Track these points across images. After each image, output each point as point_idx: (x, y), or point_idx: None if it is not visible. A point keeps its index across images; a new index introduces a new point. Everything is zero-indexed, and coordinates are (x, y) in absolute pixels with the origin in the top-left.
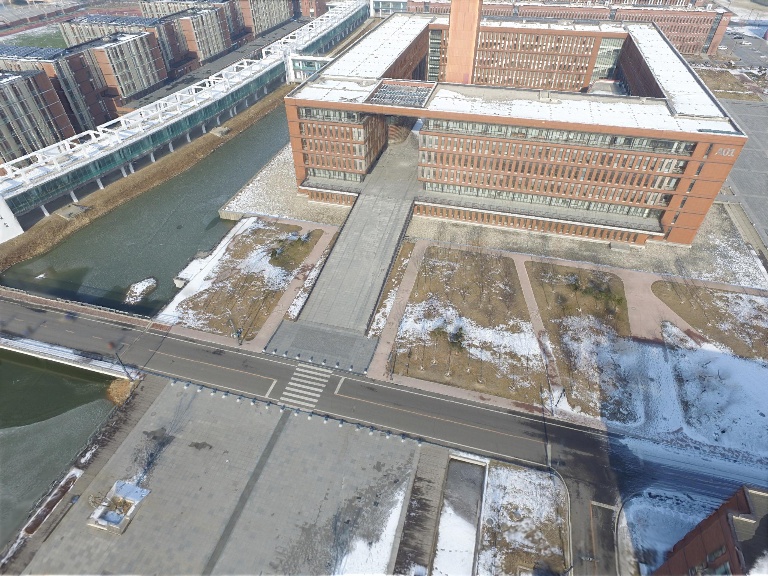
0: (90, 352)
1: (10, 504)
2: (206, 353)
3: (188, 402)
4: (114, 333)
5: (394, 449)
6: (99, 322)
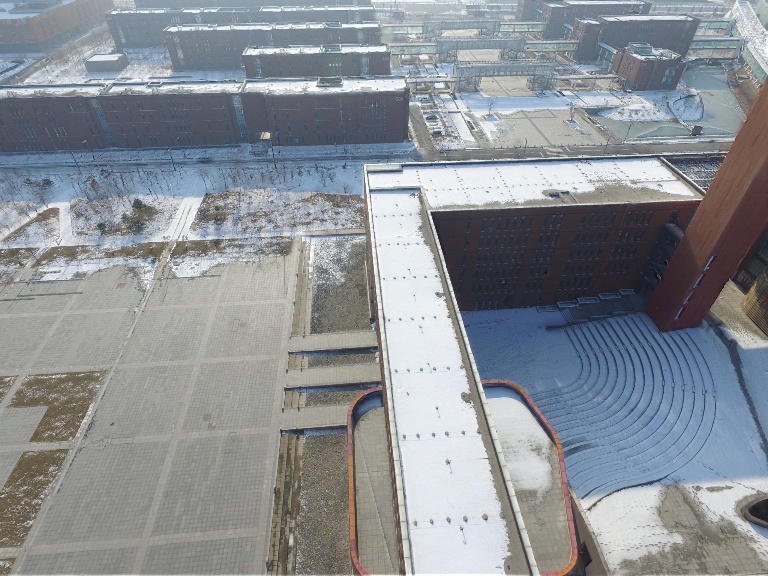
0: (660, 144)
1: (608, 125)
2: (613, 152)
3: (593, 141)
4: (665, 150)
5: (502, 145)
6: (681, 151)
